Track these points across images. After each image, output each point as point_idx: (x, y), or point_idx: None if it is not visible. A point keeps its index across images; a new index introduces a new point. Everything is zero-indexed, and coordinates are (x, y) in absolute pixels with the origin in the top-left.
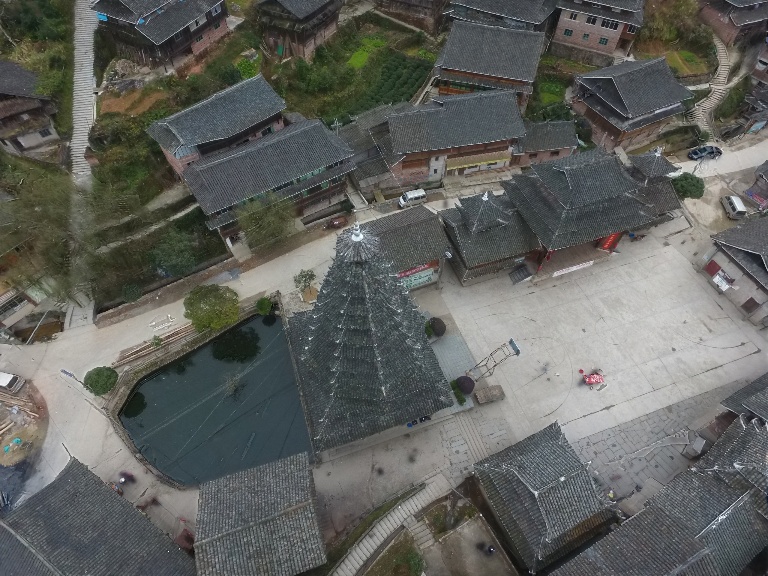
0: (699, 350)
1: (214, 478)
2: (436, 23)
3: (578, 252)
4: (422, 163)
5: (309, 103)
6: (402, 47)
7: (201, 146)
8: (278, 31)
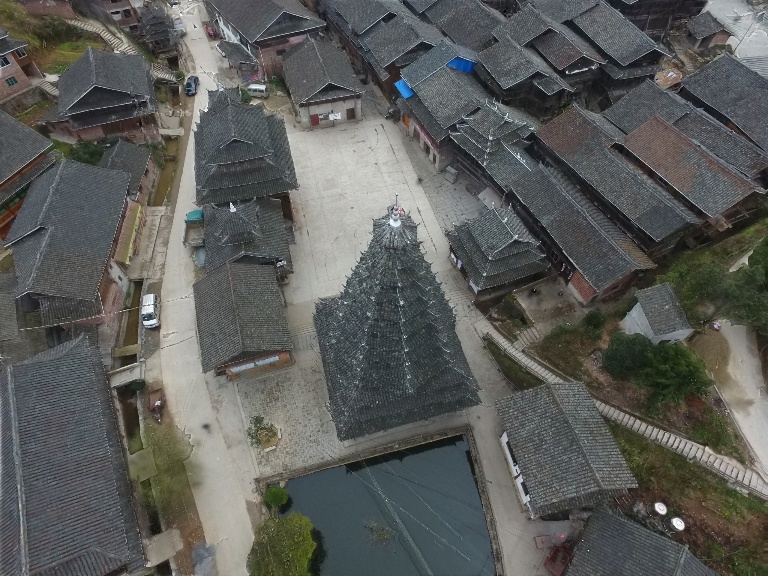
0: (378, 152)
1: (467, 571)
2: None
3: None
4: (106, 286)
5: None
6: None
7: None
8: None
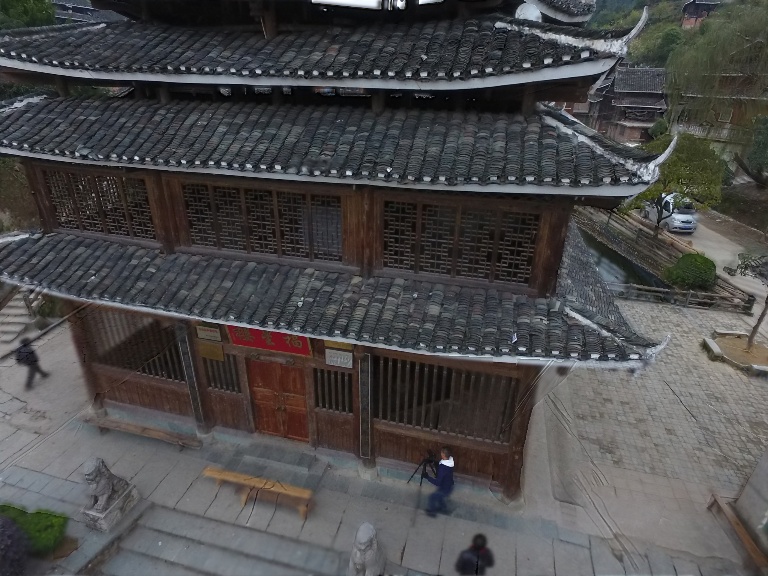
0: None
1: None
2: None
3: None
4: None
5: None
6: None
7: None
8: None
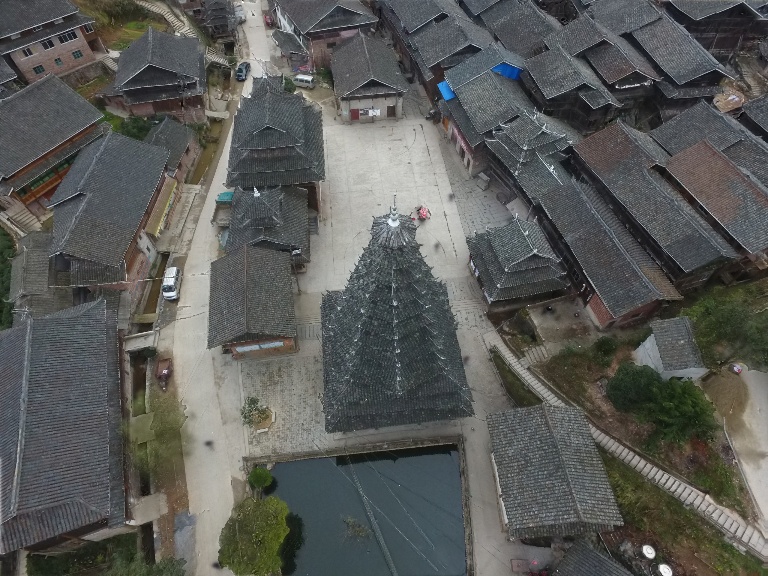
0: (413, 151)
1: None
2: None
3: None
4: (133, 255)
5: None
6: None
7: None
8: None
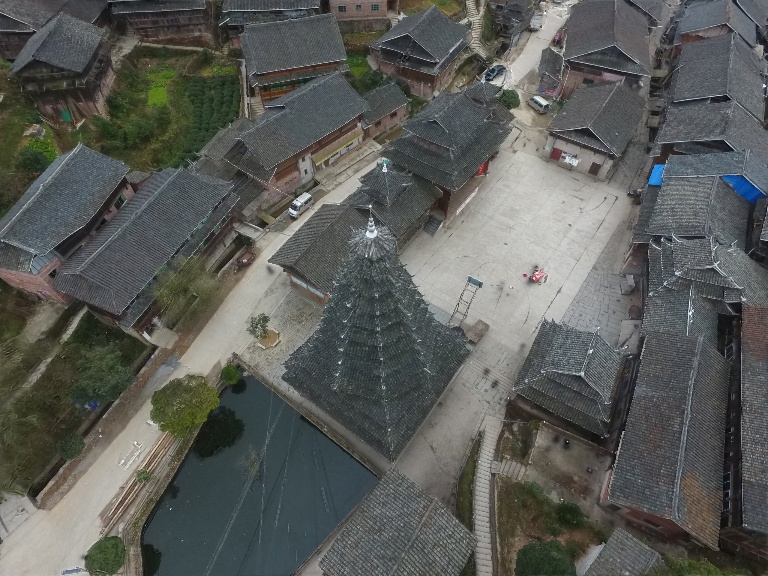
0: (584, 217)
1: (285, 567)
2: (214, 37)
3: (463, 186)
4: (291, 169)
5: (137, 158)
6: (193, 71)
7: (57, 248)
8: (54, 95)
